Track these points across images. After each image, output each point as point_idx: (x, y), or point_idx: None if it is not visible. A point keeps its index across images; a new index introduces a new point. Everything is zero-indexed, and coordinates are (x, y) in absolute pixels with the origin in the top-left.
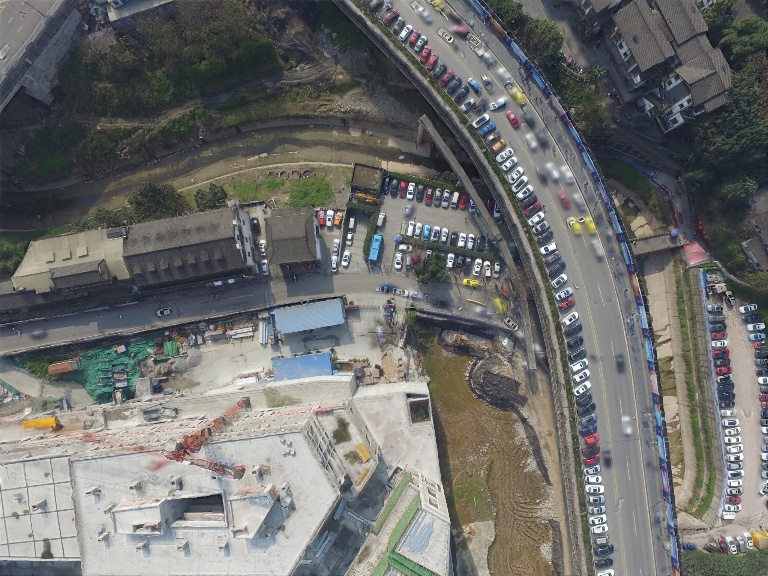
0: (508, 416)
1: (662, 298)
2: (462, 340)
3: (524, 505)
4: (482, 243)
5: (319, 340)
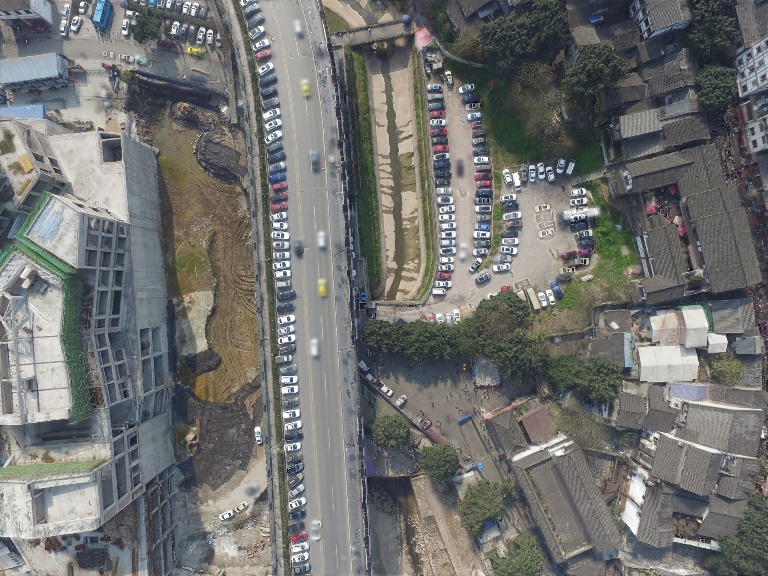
0: (232, 189)
1: (405, 94)
2: (185, 108)
3: (245, 278)
4: (204, 10)
5: (46, 102)
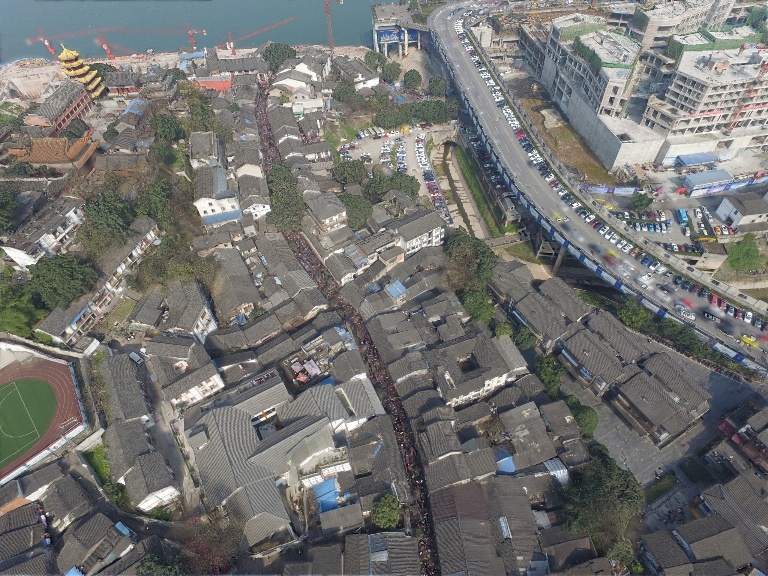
0: None
1: None
2: None
3: None
4: None
5: None
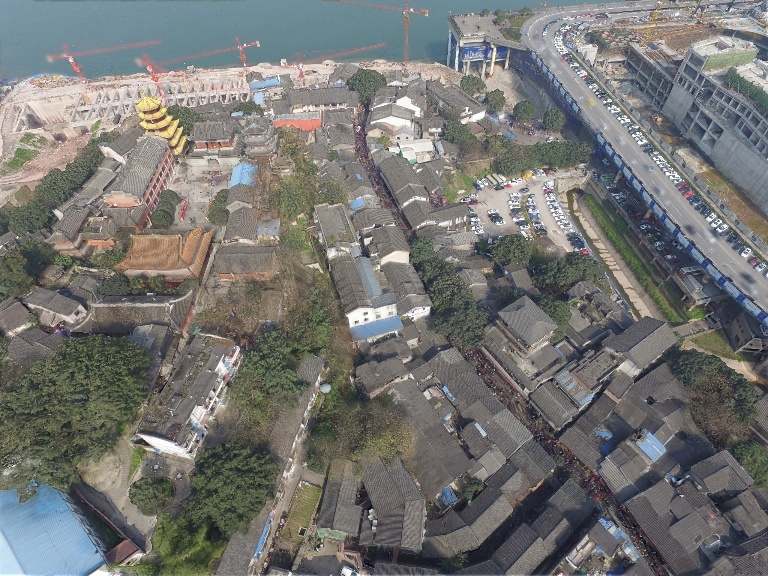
0: None
1: None
2: None
3: None
4: None
5: None
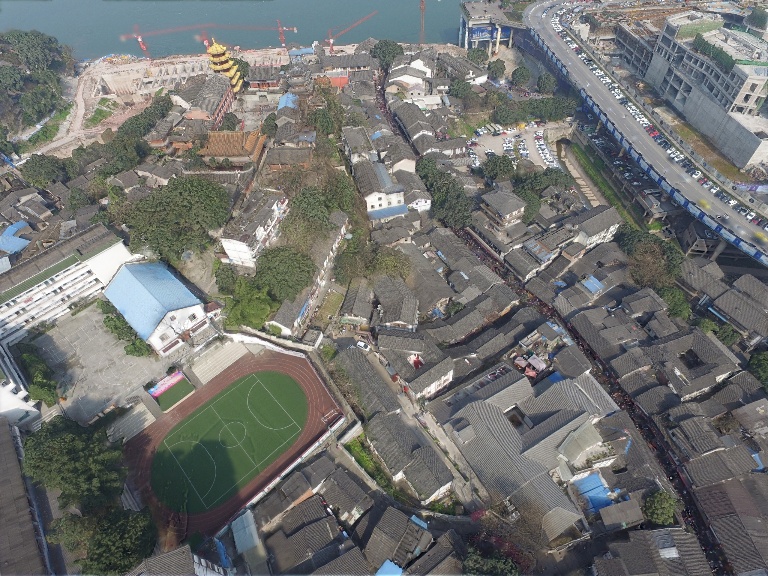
0: None
1: None
2: None
3: None
4: None
5: None
